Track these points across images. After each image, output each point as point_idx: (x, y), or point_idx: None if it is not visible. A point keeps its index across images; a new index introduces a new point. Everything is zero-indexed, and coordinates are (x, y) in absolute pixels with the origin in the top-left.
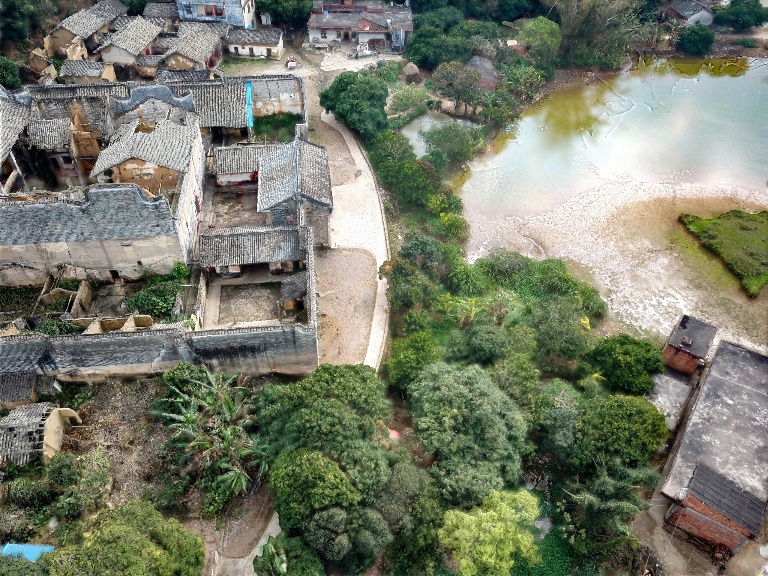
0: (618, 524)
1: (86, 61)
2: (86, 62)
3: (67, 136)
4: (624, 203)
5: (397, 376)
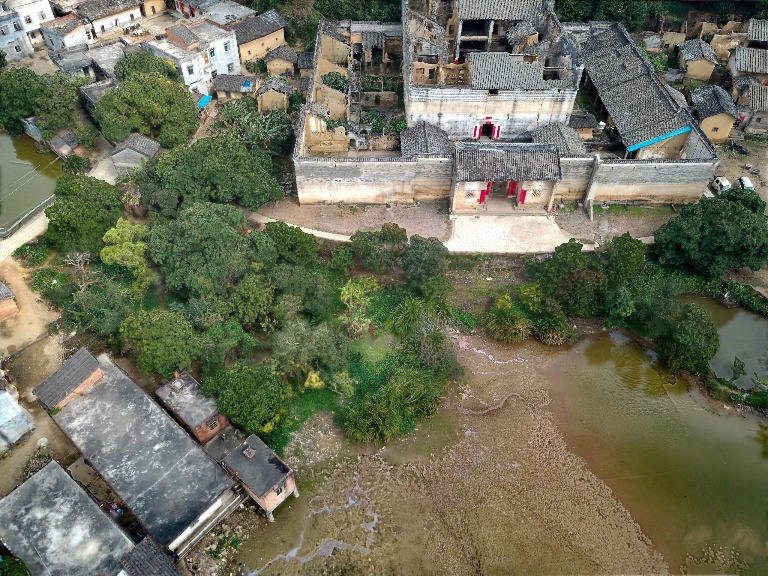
0: (84, 293)
1: (702, 47)
2: (701, 48)
3: (518, 38)
4: (609, 569)
5: (269, 223)
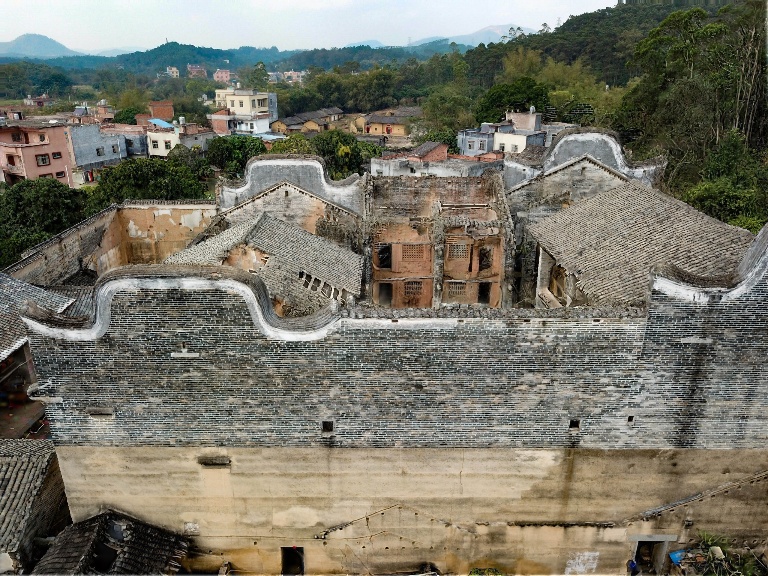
0: None
1: None
2: None
3: None
4: None
5: None
